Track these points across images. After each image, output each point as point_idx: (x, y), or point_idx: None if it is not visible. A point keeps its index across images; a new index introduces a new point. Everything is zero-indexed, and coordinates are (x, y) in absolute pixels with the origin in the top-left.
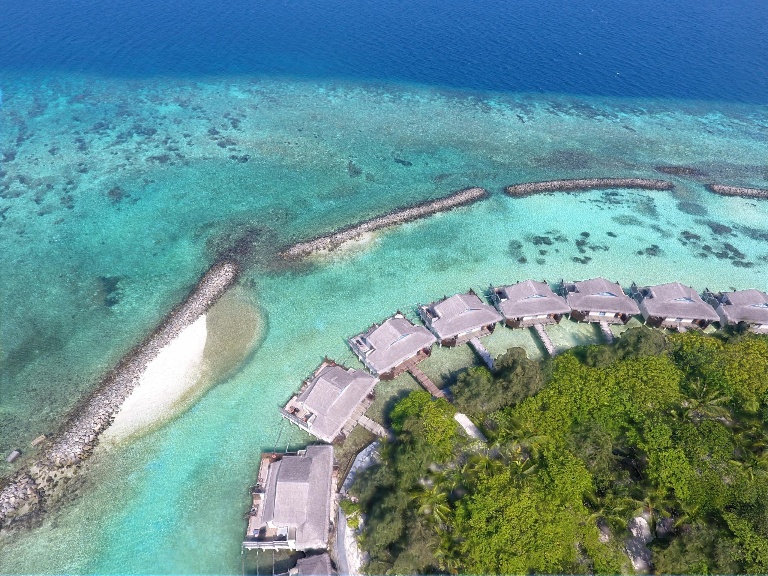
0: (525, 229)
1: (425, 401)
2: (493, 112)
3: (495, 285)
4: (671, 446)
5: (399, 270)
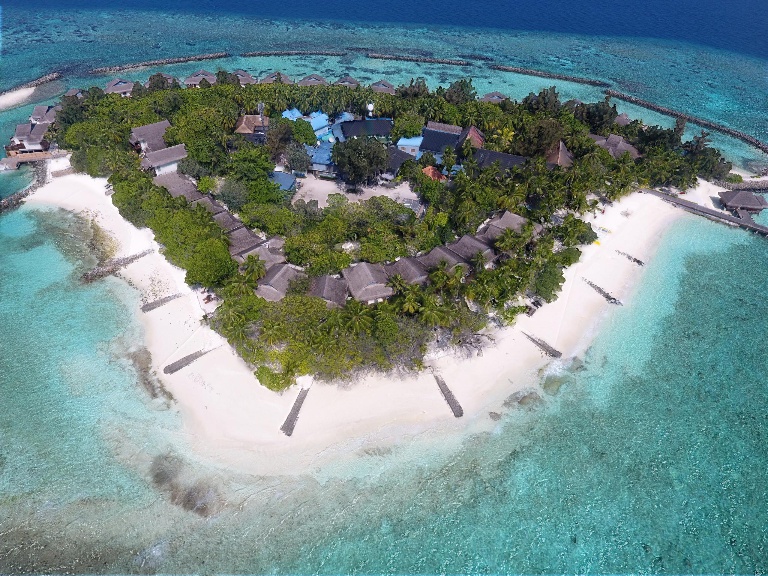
0: (237, 67)
1: None
2: (272, 26)
3: None
4: None
5: None
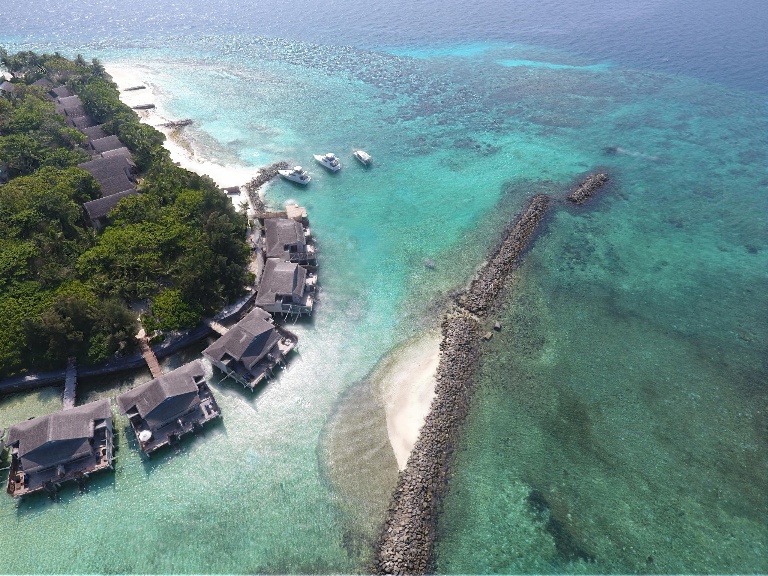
0: None
1: None
2: None
3: None
4: None
5: None
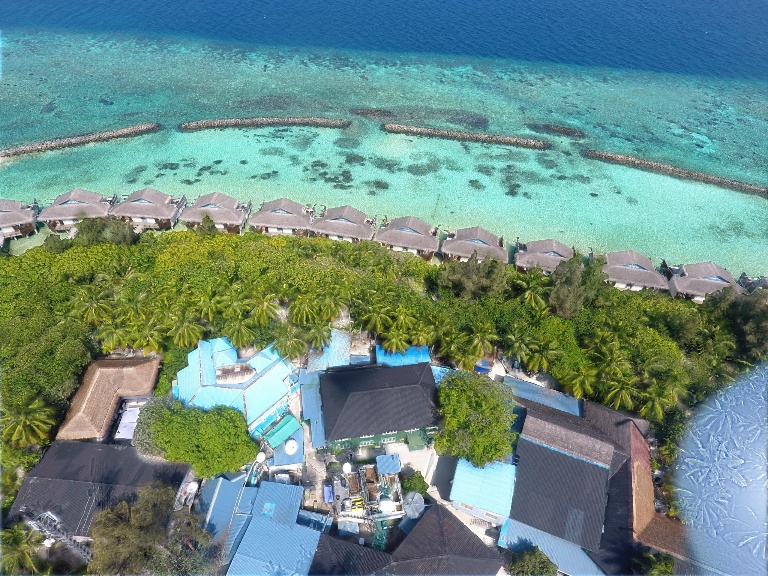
0: (163, 157)
1: None
2: (244, 62)
3: None
4: (10, 301)
5: (3, 187)
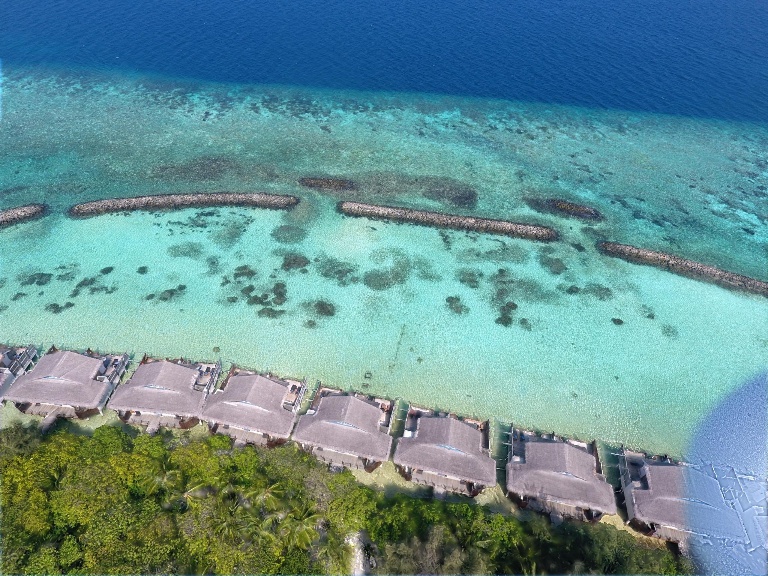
0: (34, 263)
1: None
2: (181, 108)
3: None
4: None
5: None
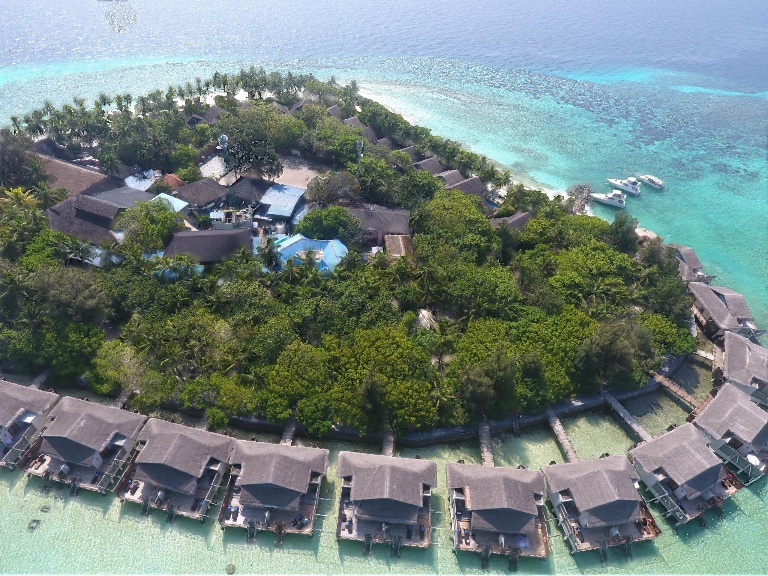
0: None
1: (677, 342)
2: None
3: (644, 569)
4: None
5: None
